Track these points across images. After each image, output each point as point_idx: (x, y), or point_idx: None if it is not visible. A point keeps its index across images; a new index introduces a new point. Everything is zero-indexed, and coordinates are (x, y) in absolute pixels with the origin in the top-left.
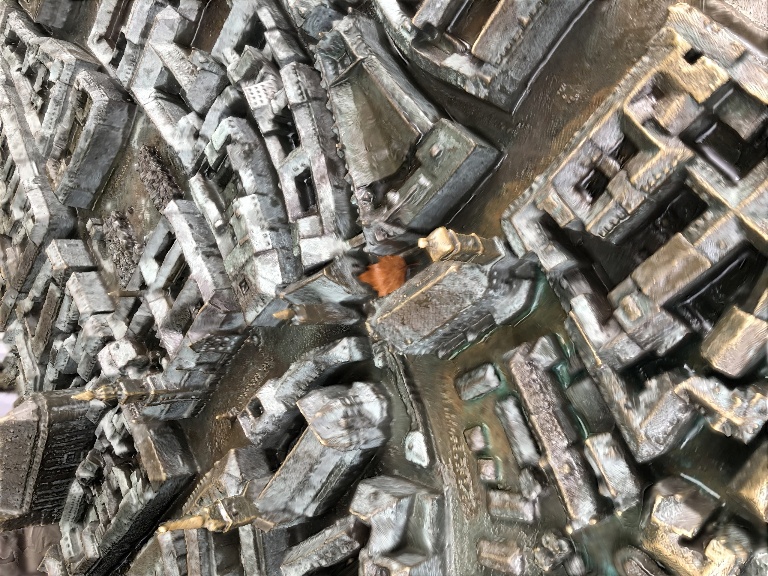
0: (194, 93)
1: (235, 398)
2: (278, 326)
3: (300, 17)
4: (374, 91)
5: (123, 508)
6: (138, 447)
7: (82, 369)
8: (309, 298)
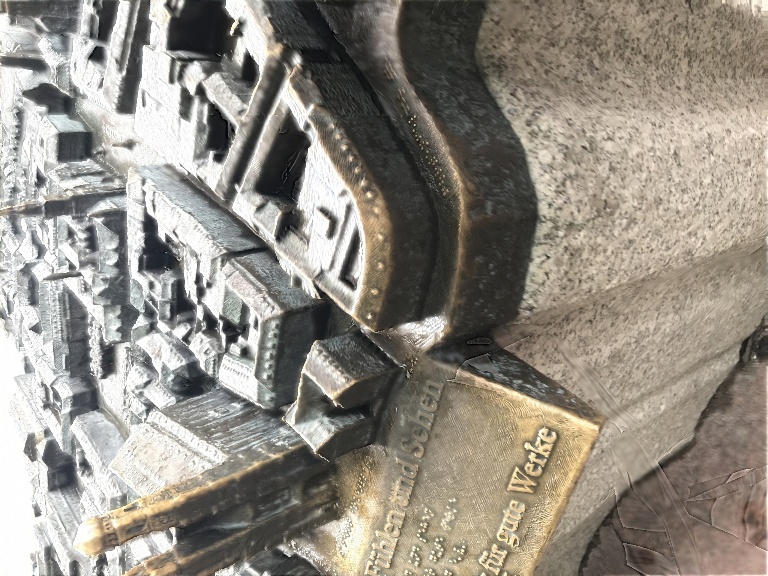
0: (41, 277)
1: (127, 152)
2: (90, 132)
3: (9, 185)
4: (7, 108)
5: (160, 220)
6: (127, 224)
7: (159, 400)
8: (33, 81)
